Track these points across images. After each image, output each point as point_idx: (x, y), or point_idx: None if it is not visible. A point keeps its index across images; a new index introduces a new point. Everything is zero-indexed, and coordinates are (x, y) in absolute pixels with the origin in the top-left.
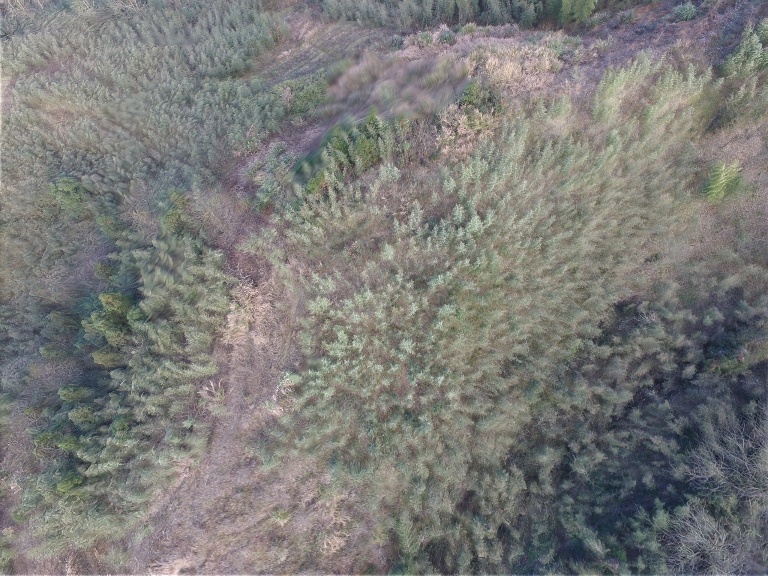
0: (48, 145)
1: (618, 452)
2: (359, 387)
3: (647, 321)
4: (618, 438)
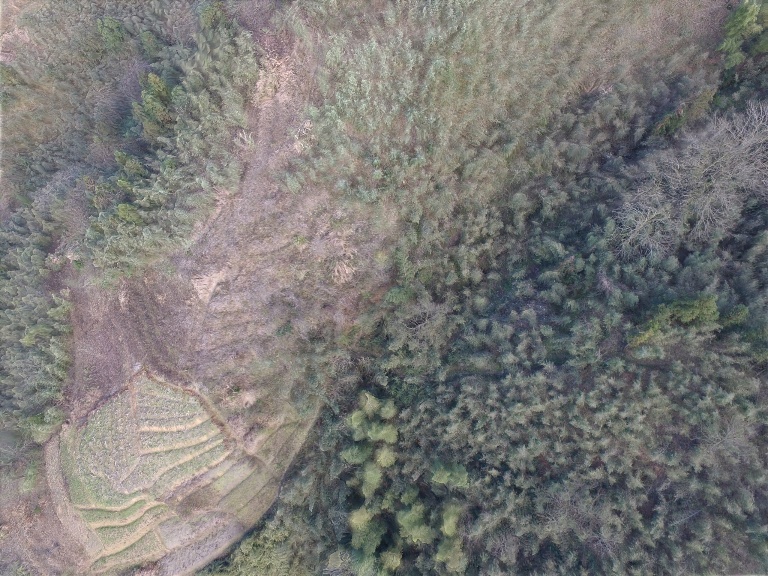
0: None
1: (579, 195)
2: (366, 123)
3: (606, 93)
4: (580, 185)
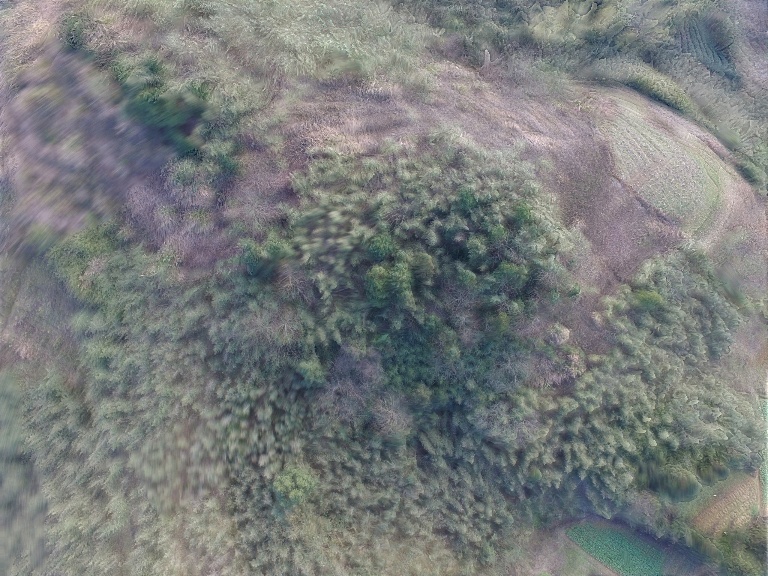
0: (244, 573)
1: None
2: None
3: None
4: None
